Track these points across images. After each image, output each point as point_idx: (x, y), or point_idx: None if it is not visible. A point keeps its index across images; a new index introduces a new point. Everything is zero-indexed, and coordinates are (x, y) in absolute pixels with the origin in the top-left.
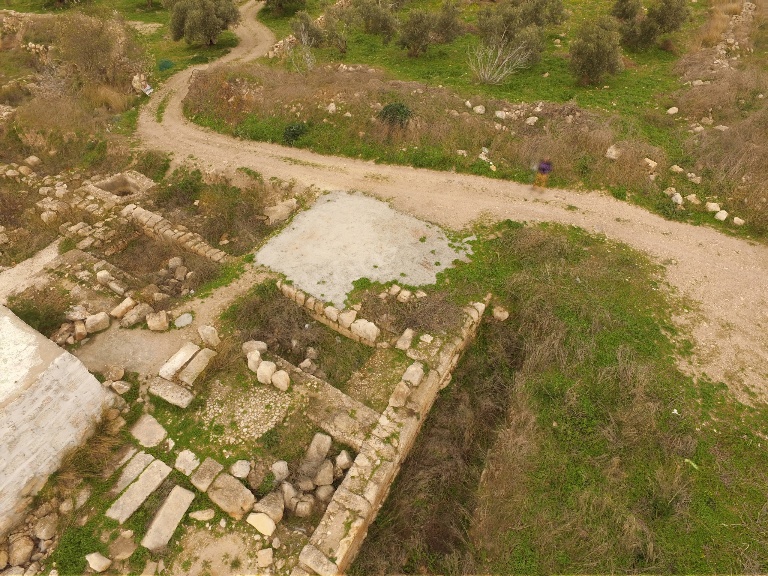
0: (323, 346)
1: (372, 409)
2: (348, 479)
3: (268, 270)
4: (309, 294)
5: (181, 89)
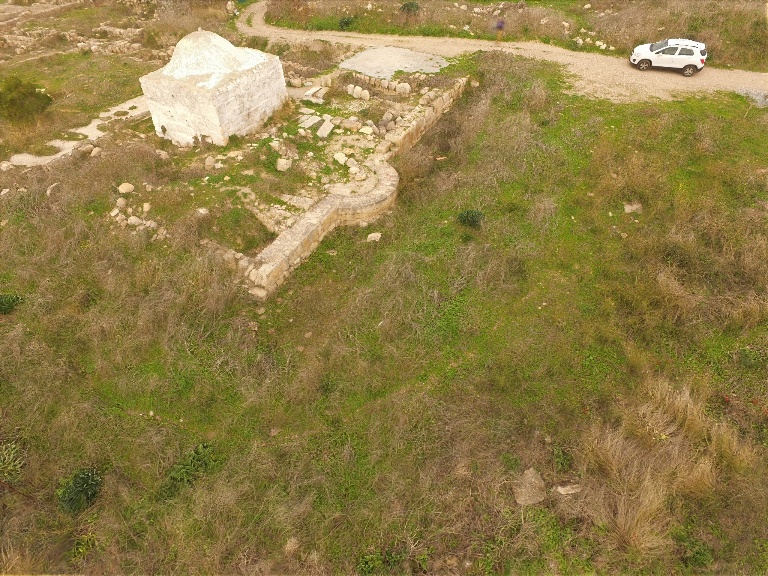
0: (381, 97)
1: (411, 106)
2: (403, 121)
3: (347, 69)
4: (371, 77)
5: (259, 12)
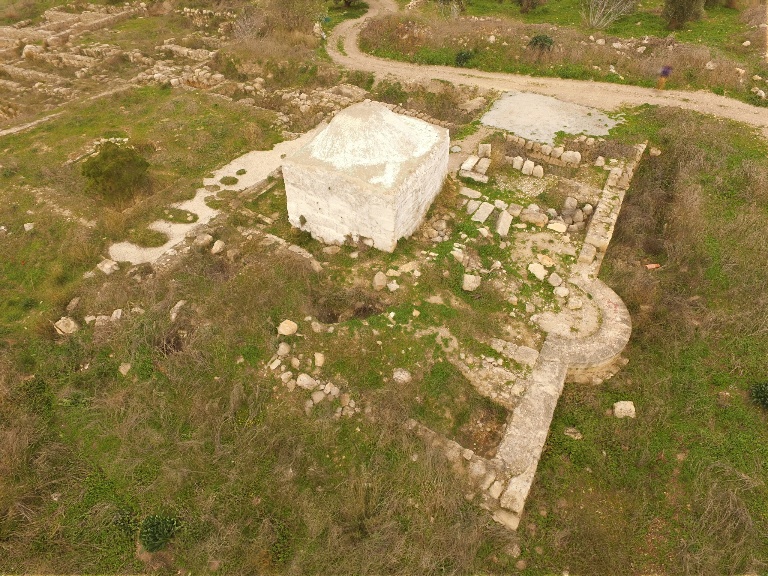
0: (544, 167)
1: None
2: (598, 212)
3: (494, 128)
4: (528, 139)
5: (348, 35)
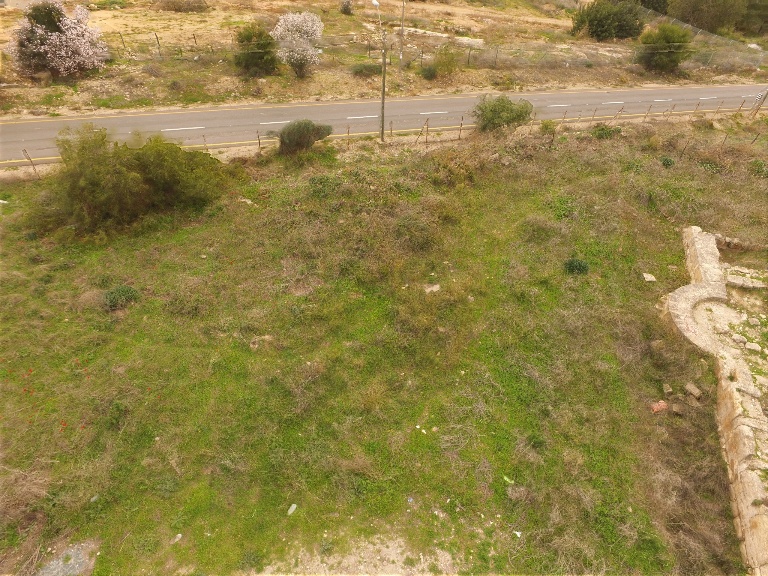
0: None
1: None
2: None
3: None
4: None
5: None
